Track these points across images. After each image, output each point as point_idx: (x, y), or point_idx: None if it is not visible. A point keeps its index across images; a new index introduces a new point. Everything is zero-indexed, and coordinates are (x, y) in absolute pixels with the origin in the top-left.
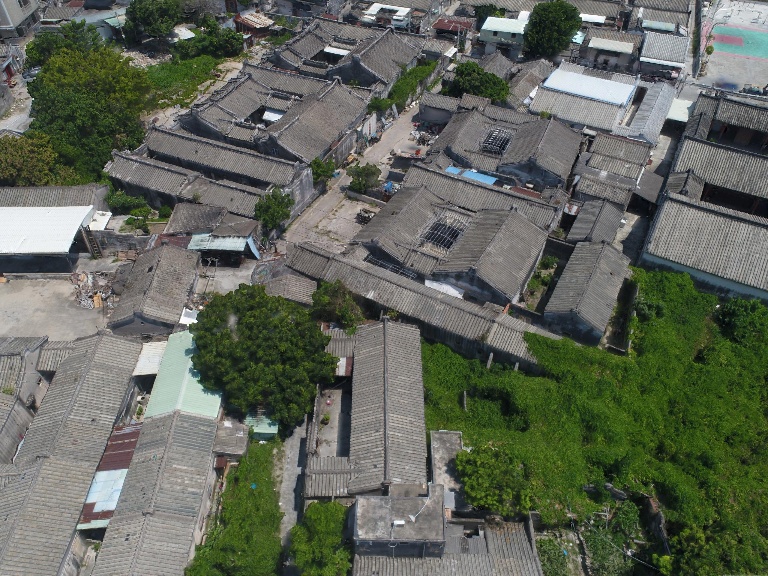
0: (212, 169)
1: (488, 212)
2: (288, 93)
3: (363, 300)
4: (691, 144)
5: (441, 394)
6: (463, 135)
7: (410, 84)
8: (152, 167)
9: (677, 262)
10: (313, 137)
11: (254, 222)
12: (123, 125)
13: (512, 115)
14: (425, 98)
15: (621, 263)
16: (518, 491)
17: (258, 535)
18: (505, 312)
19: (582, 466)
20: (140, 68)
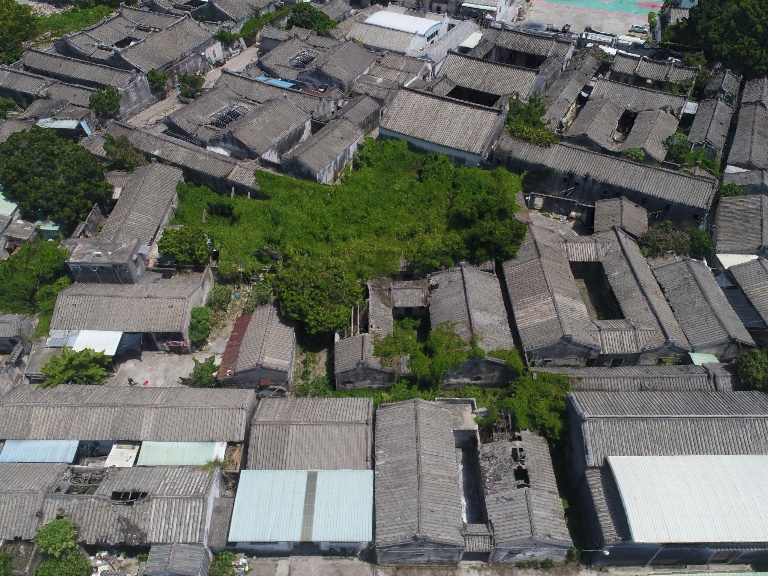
0: (71, 79)
1: (269, 102)
2: (154, 29)
3: (153, 157)
4: (452, 57)
5: (190, 213)
6: (278, 54)
7: (258, 22)
8: (19, 74)
9: (399, 132)
10: (156, 55)
11: (88, 110)
12: (3, 45)
13: (329, 42)
14: (264, 31)
15: (354, 132)
16: (194, 245)
17: (18, 277)
18: (253, 162)
19: (261, 244)
20: (45, 15)
